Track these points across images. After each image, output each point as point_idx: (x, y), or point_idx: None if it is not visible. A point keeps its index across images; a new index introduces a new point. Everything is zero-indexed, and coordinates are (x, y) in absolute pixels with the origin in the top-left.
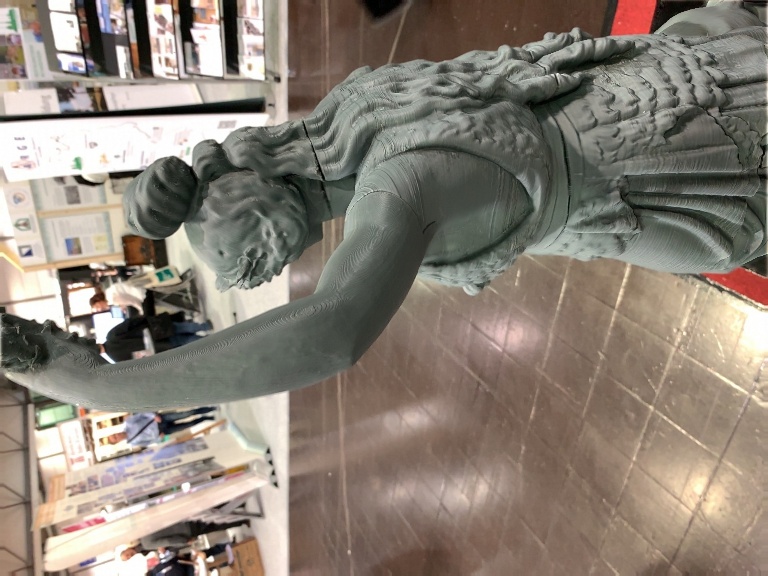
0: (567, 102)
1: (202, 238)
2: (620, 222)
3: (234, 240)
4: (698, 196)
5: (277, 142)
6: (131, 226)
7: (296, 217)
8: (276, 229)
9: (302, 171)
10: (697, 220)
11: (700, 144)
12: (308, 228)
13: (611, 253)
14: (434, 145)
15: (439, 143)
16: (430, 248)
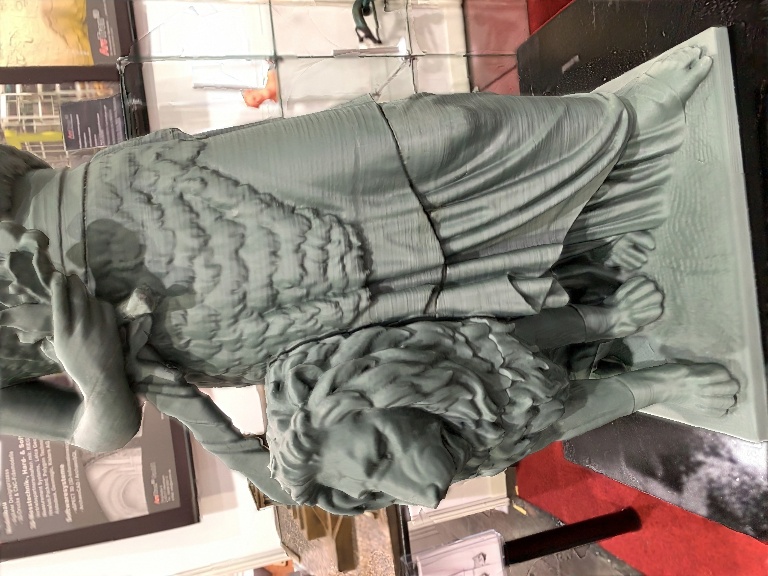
0: None
1: None
2: None
3: None
4: None
5: None
6: None
7: None
8: None
9: None
10: None
11: None
12: None
13: None
14: None
15: None
16: None
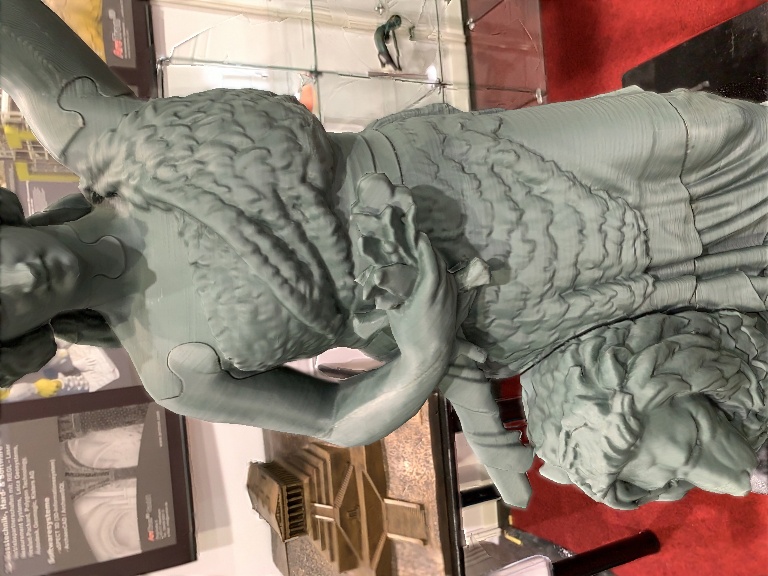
0: None
1: None
2: None
3: None
4: None
5: None
6: None
7: None
8: None
9: None
10: None
11: None
12: None
13: (481, 118)
14: None
15: None
16: None
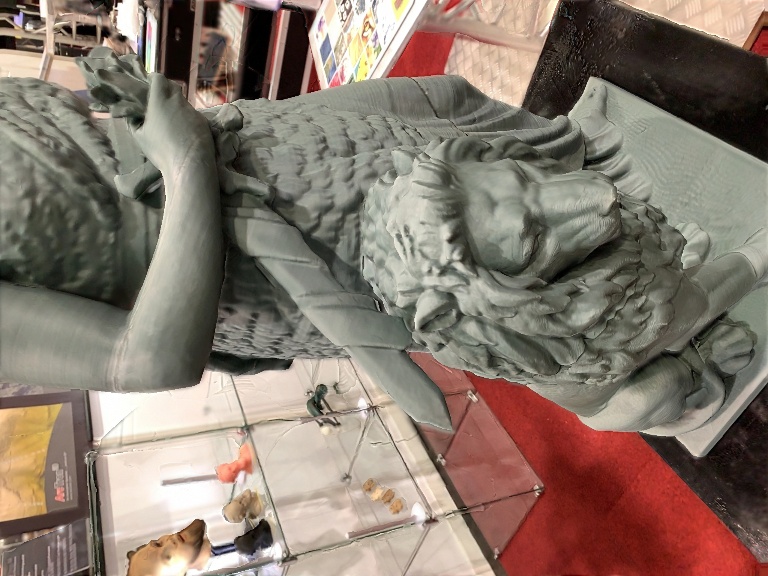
0: None
1: None
2: None
3: None
4: None
5: None
6: None
7: None
8: None
9: None
10: None
11: None
12: None
13: None
14: None
15: None
16: None
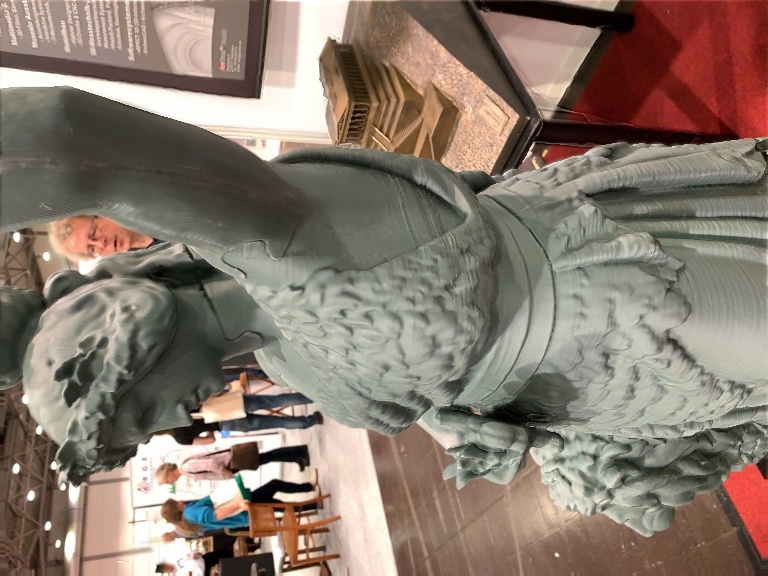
0: (485, 189)
1: (31, 356)
2: (623, 237)
3: (67, 336)
4: (728, 219)
5: (145, 252)
6: None
7: (152, 292)
8: (122, 305)
9: (166, 257)
10: (763, 248)
11: (658, 157)
12: (170, 306)
13: (669, 308)
14: (293, 157)
15: (297, 154)
16: (318, 244)
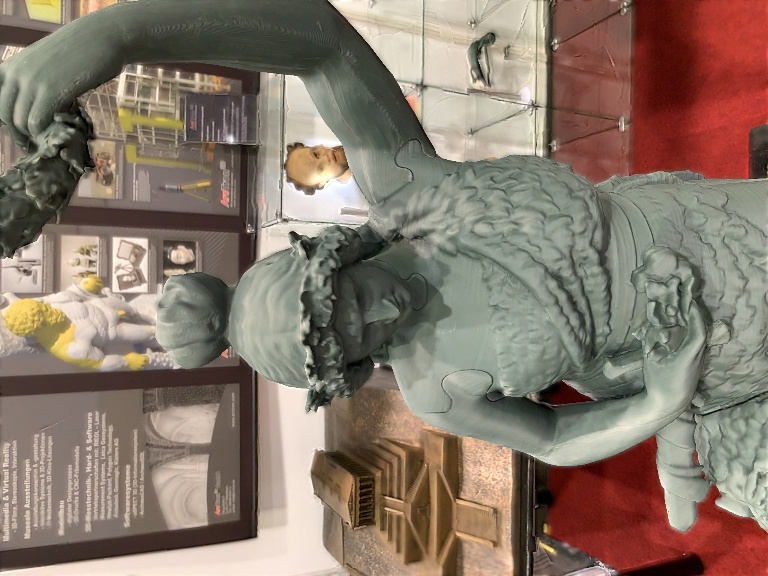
0: None
1: None
2: None
3: None
4: None
5: None
6: (162, 308)
7: None
8: None
9: None
10: None
11: None
12: None
13: None
14: None
15: None
16: None
